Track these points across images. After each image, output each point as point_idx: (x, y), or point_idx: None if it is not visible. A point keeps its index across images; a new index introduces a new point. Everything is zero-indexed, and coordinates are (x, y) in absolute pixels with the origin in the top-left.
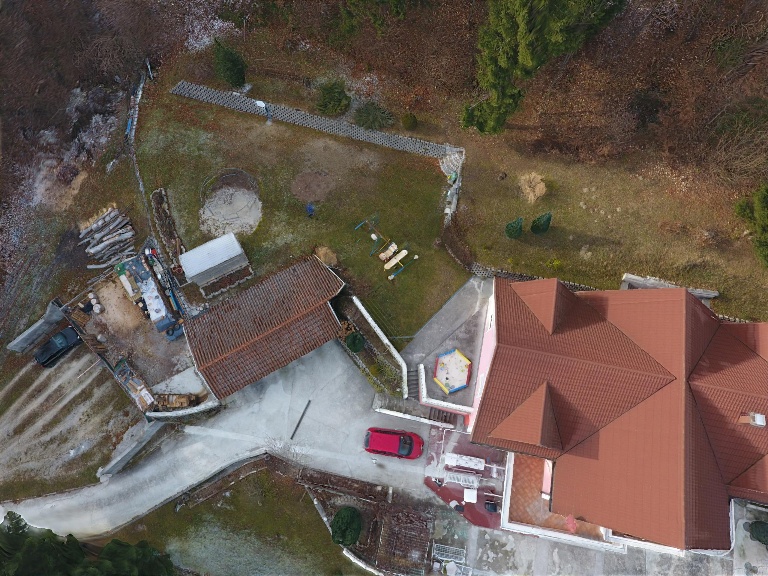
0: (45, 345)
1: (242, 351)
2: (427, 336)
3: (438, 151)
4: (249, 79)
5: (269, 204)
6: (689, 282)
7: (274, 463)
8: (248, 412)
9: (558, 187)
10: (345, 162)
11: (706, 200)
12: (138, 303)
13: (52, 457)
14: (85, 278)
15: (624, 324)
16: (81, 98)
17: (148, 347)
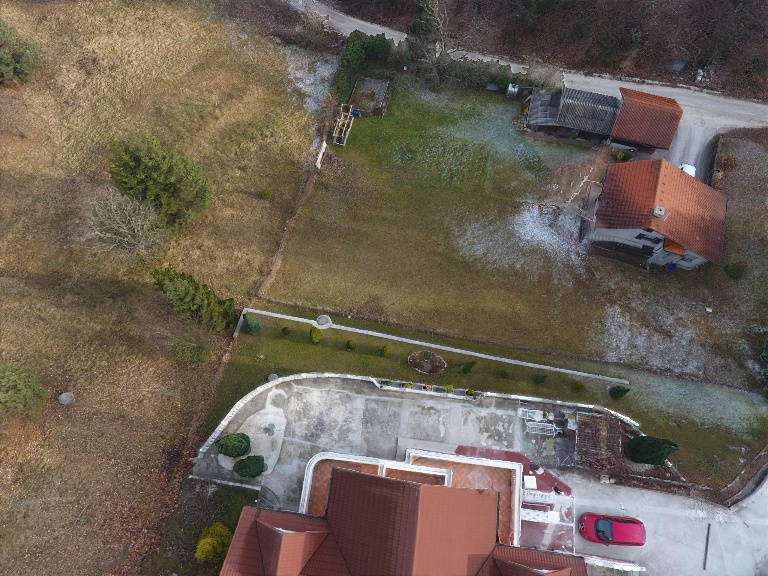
0: None
1: None
2: None
3: None
4: None
5: None
6: None
7: (717, 497)
8: (763, 551)
9: None
10: None
11: None
12: None
13: None
14: None
15: None
16: None
17: None
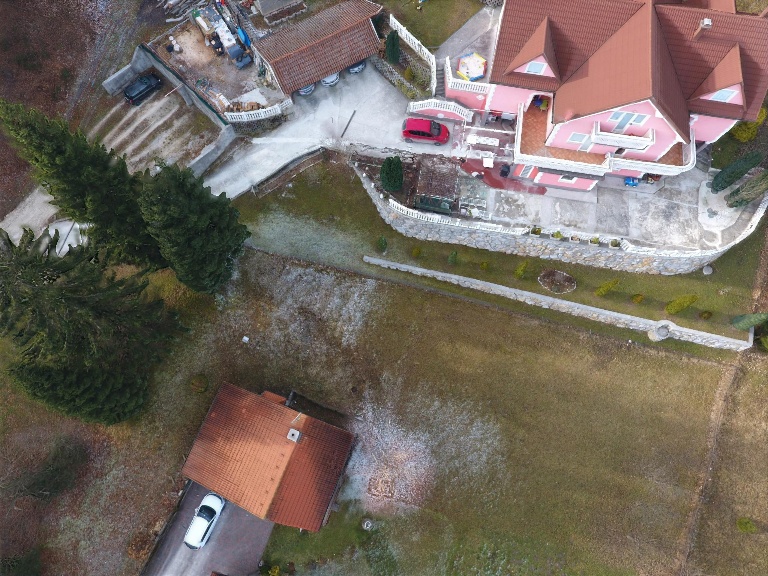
0: (132, 85)
1: (303, 52)
2: (450, 46)
3: None
4: None
5: None
6: None
7: (328, 154)
8: (305, 121)
9: None
10: None
11: None
12: (211, 41)
13: None
14: (164, 30)
15: None
16: None
17: (220, 75)
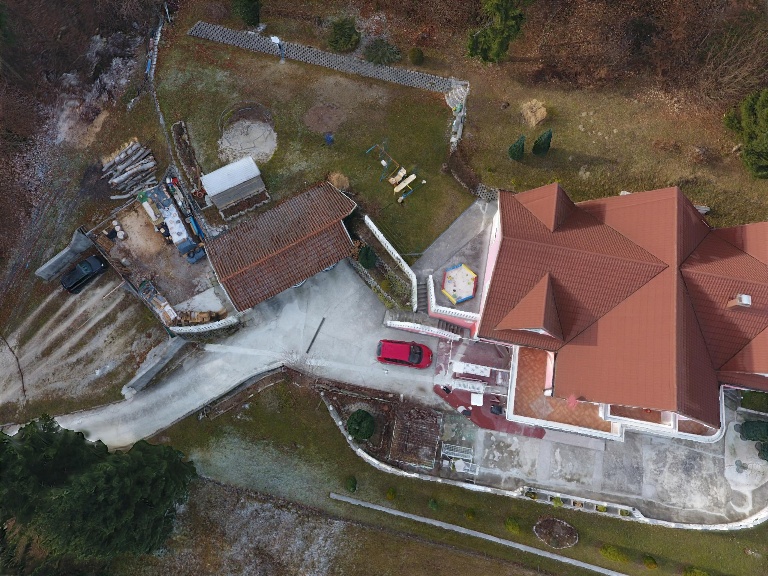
0: (71, 272)
1: (261, 265)
2: (435, 253)
3: (444, 85)
4: (263, 19)
5: (284, 135)
6: None
7: (291, 375)
8: (266, 329)
9: (558, 113)
10: (355, 97)
11: (697, 120)
12: (160, 229)
13: (79, 377)
14: (108, 208)
15: (620, 225)
16: (101, 43)
17: (170, 270)
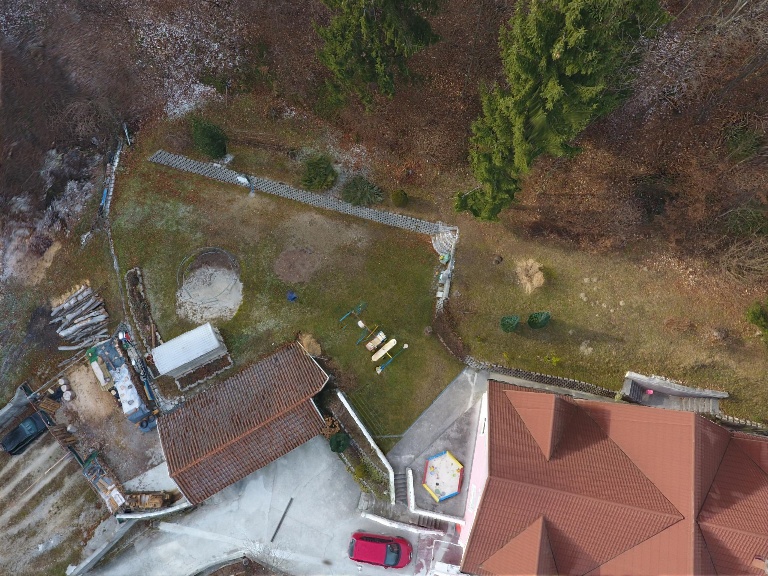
0: (13, 431)
1: (218, 454)
2: (416, 435)
3: (430, 228)
4: (231, 149)
5: (250, 285)
6: (697, 382)
7: (253, 568)
8: (226, 510)
9: (557, 275)
10: (332, 239)
11: (716, 296)
12: (111, 391)
13: (20, 552)
14: (56, 360)
15: (627, 445)
16: (56, 161)
17: (121, 438)
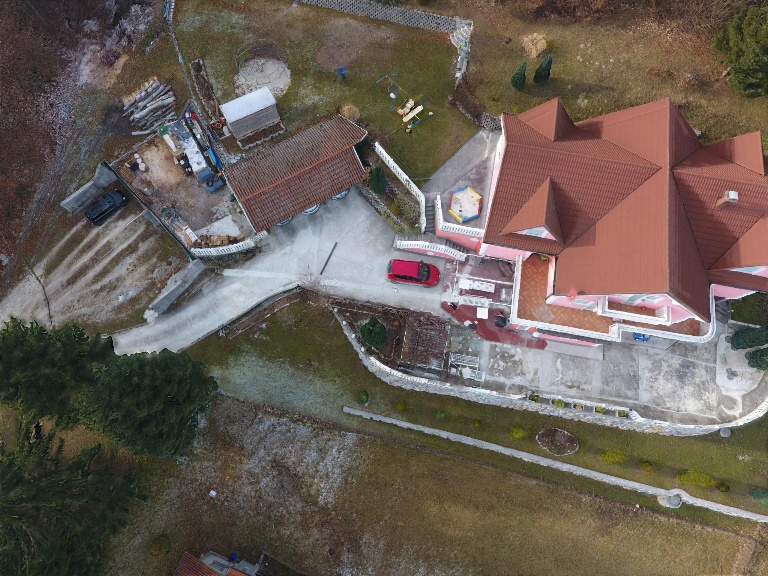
0: (94, 204)
1: (278, 187)
2: (442, 178)
3: (449, 25)
4: None
5: (297, 72)
6: None
7: (306, 294)
8: (281, 253)
9: (557, 45)
10: (365, 37)
11: (689, 48)
12: (180, 161)
13: (102, 303)
14: (130, 144)
15: (617, 138)
16: None
17: (189, 199)
